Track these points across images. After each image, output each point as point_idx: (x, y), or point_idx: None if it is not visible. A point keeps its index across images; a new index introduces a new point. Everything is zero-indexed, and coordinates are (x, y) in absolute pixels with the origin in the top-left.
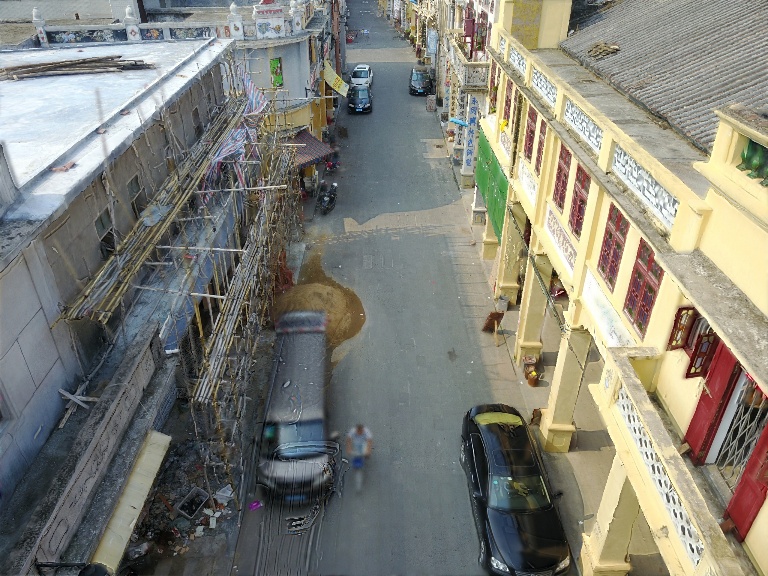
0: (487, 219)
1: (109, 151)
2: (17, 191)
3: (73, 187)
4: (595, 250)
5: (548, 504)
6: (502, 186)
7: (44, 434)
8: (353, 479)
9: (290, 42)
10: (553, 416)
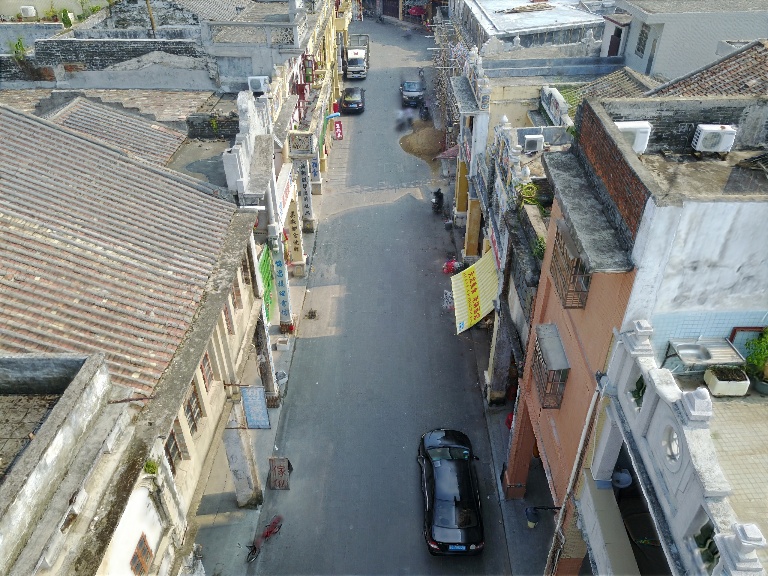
0: None
1: None
2: None
3: None
4: None
5: None
6: None
7: None
8: None
9: None
10: None
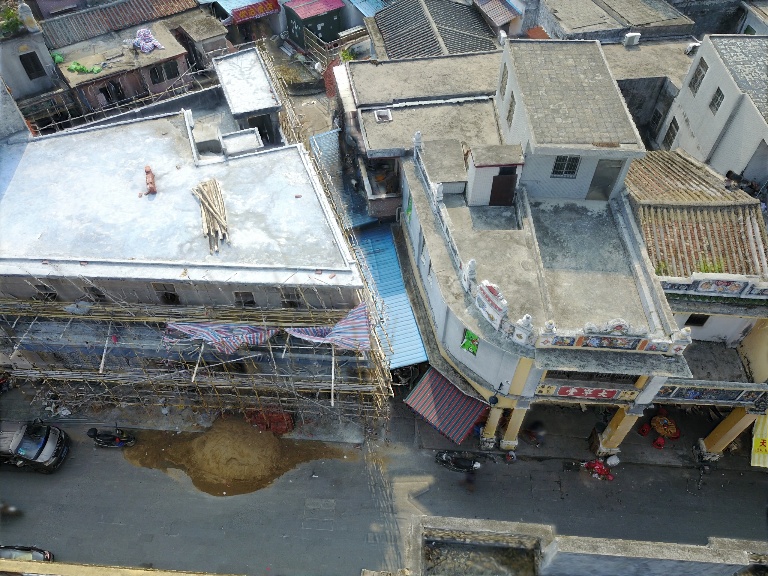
0: None
1: (13, 273)
2: None
3: None
4: None
5: None
6: None
7: None
8: (50, 480)
9: None
10: None
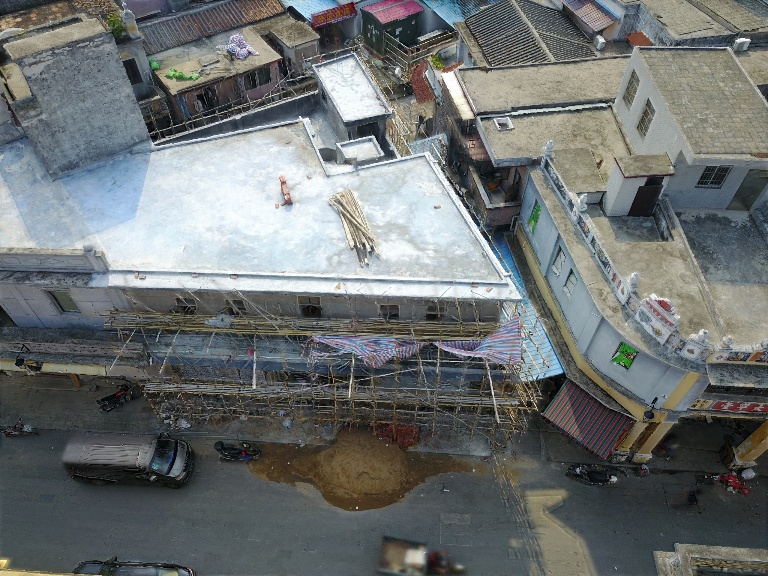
0: None
1: (163, 287)
2: (107, 270)
3: (117, 286)
4: None
5: None
6: None
7: (102, 328)
8: (178, 495)
9: None
10: None
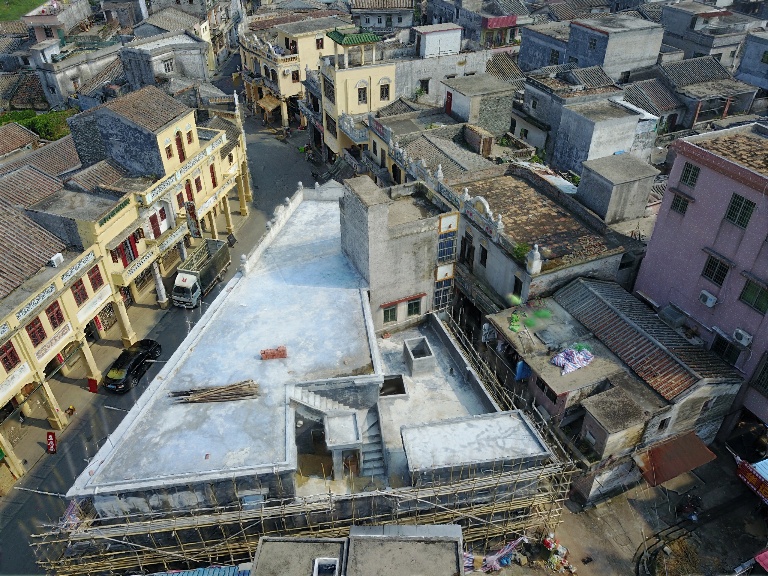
0: None
1: None
2: None
3: None
4: None
5: (130, 348)
6: None
7: None
8: None
9: None
10: (97, 368)
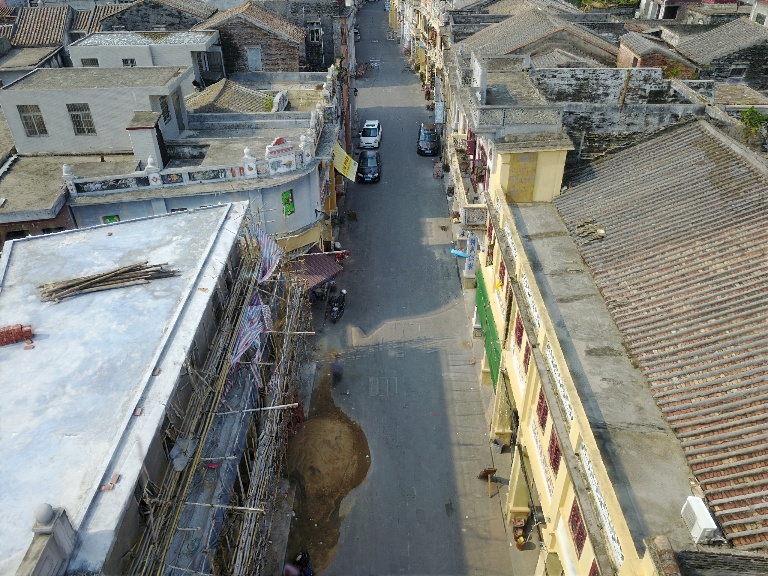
0: (485, 352)
1: (147, 447)
2: (76, 534)
3: (120, 515)
4: (567, 504)
5: None
6: (497, 344)
7: None
8: None
9: (301, 176)
10: None
